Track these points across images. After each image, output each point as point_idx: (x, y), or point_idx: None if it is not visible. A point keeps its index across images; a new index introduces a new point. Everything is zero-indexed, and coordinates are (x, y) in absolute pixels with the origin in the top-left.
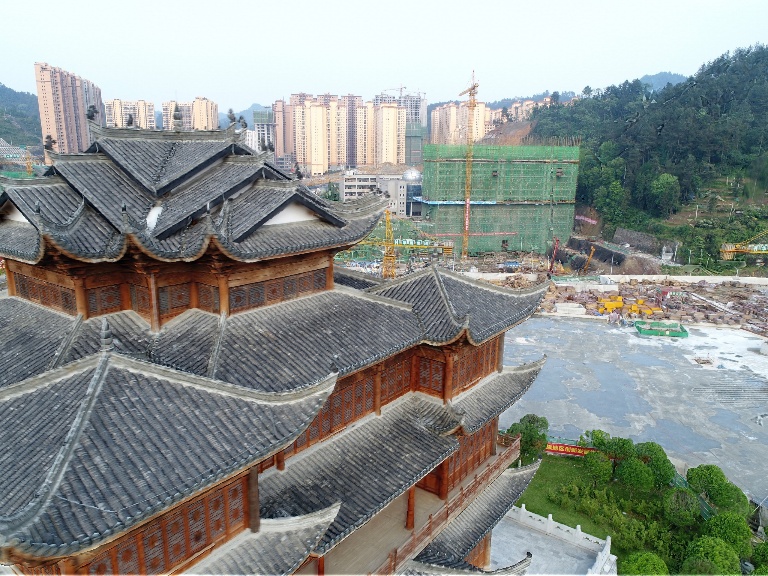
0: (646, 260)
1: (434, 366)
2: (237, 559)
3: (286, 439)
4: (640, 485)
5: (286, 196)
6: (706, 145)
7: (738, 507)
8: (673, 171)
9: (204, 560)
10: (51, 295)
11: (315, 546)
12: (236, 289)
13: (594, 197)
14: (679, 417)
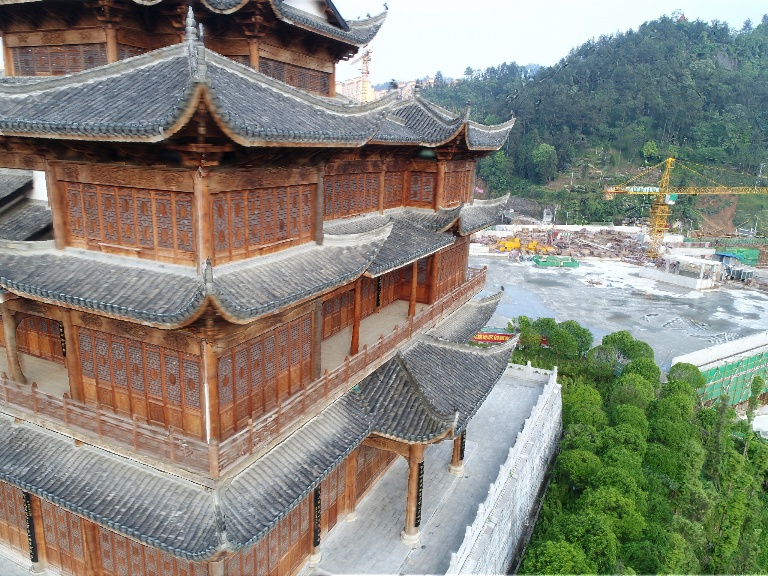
0: (530, 222)
1: (425, 178)
2: (311, 258)
3: (361, 136)
4: (566, 349)
5: None
6: (578, 119)
7: (647, 357)
8: (551, 142)
9: (286, 250)
10: (69, 60)
11: (373, 259)
12: (264, 61)
13: (481, 166)
14: (582, 318)
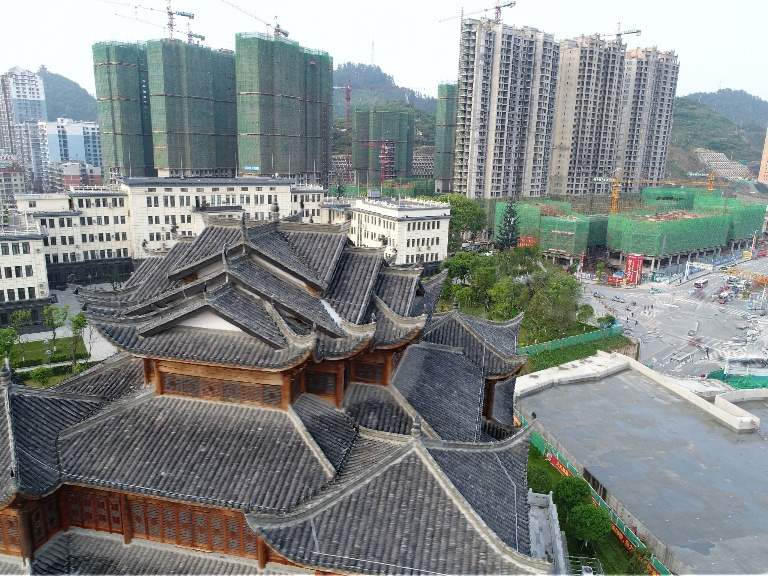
0: None
1: None
2: None
3: None
4: None
5: (198, 305)
6: None
7: None
8: None
9: None
10: None
11: None
12: (170, 374)
13: None
14: None
